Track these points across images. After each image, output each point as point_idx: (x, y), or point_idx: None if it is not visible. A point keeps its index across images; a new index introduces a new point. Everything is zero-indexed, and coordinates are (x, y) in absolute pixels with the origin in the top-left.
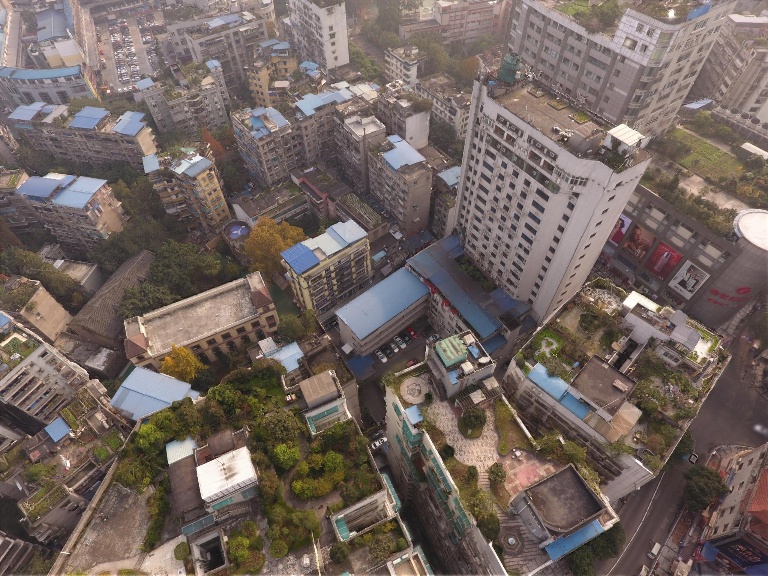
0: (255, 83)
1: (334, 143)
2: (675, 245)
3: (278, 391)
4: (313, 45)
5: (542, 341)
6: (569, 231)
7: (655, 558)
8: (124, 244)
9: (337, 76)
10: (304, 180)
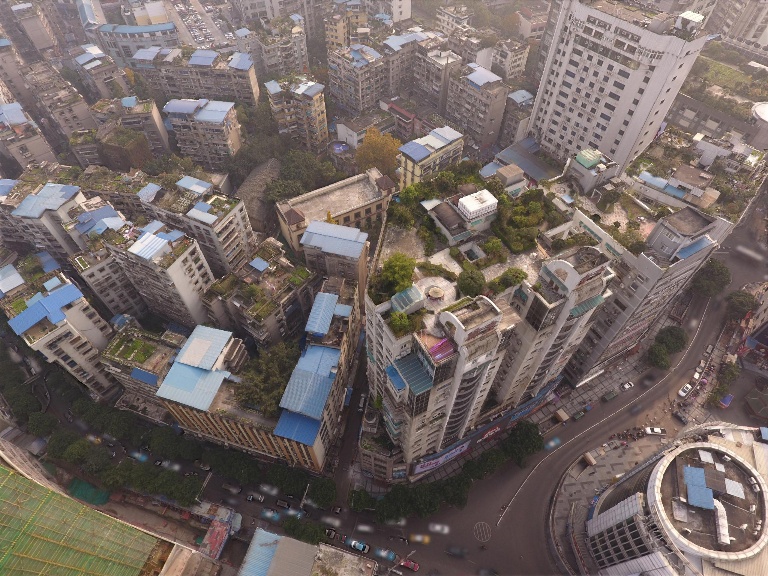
0: (332, 35)
1: (409, 80)
2: None
3: (478, 180)
4: (378, 3)
5: (640, 164)
6: (643, 102)
7: (709, 355)
8: (253, 155)
9: (403, 27)
10: (392, 106)
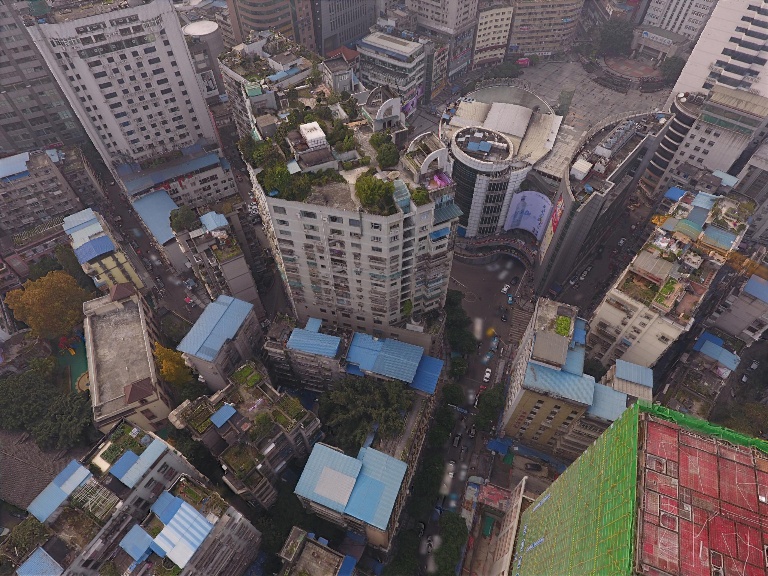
0: None
1: None
2: None
3: None
4: None
5: None
6: (178, 59)
7: None
8: None
9: None
10: None
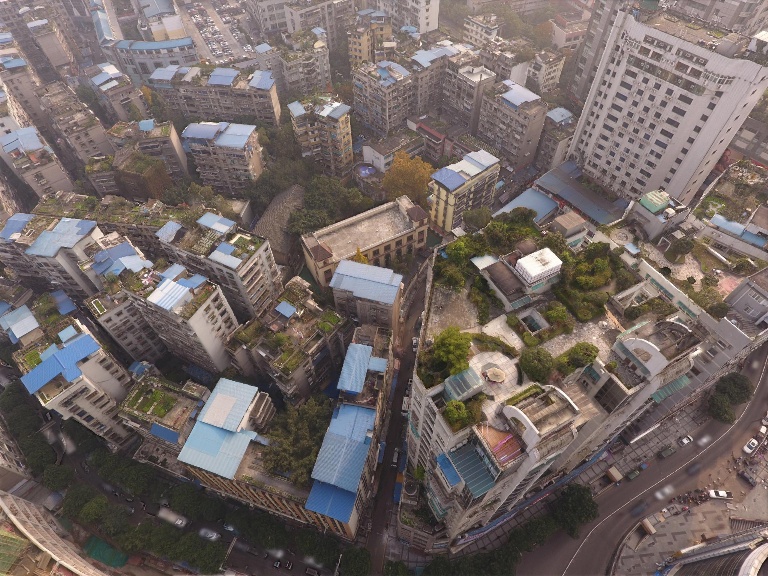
0: (355, 48)
1: (438, 96)
2: (764, 160)
3: (532, 230)
4: (404, 13)
5: None
6: (706, 129)
7: None
8: (275, 181)
9: (430, 39)
10: (421, 125)
